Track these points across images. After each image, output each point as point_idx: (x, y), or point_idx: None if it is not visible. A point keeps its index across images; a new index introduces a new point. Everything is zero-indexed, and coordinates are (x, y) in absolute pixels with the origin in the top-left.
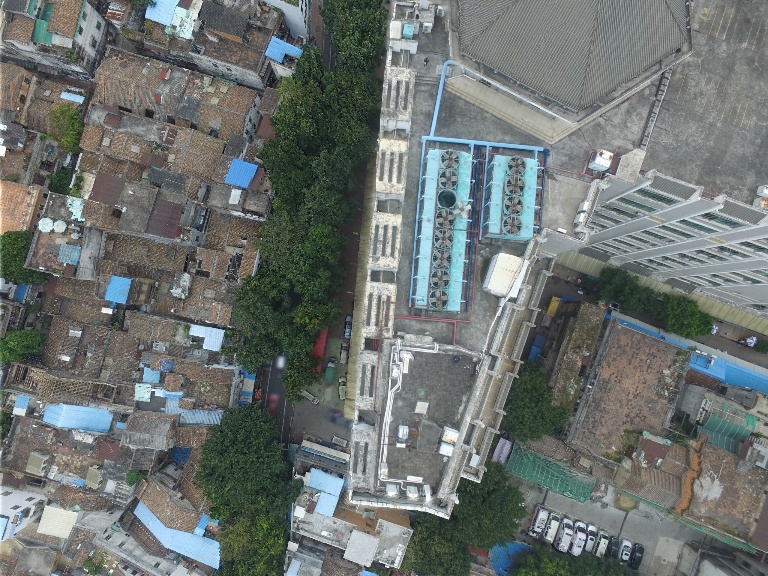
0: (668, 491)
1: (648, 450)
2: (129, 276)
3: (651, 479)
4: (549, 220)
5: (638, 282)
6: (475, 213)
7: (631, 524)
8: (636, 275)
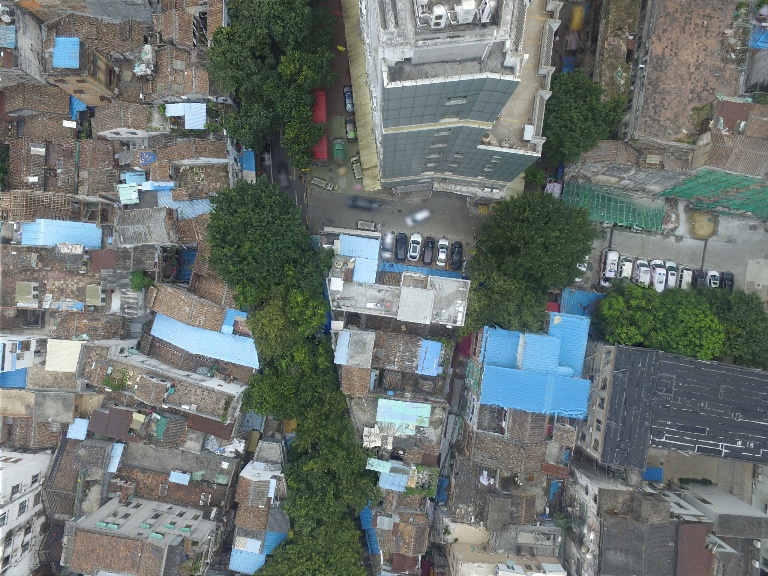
0: (760, 152)
1: (727, 114)
2: None
3: (737, 144)
4: None
5: None
6: None
7: (713, 253)
8: None
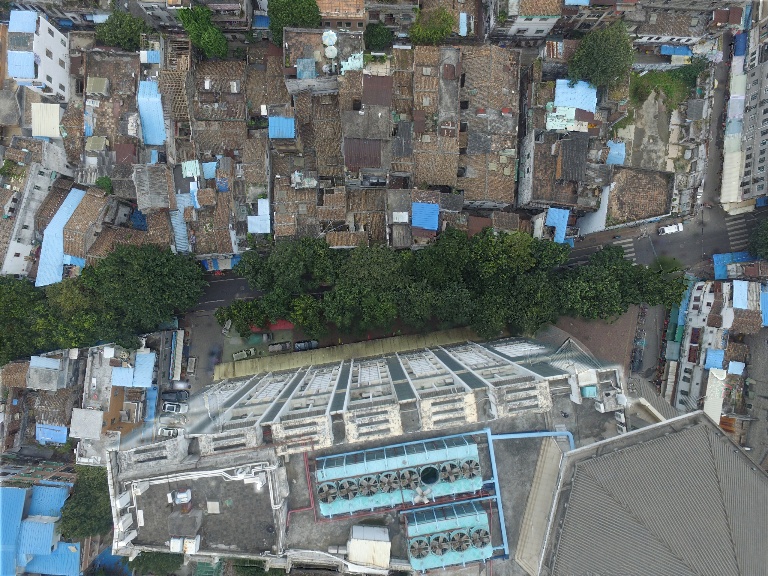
0: None
1: None
2: (300, 128)
3: None
4: (438, 575)
5: None
6: None
7: None
8: None
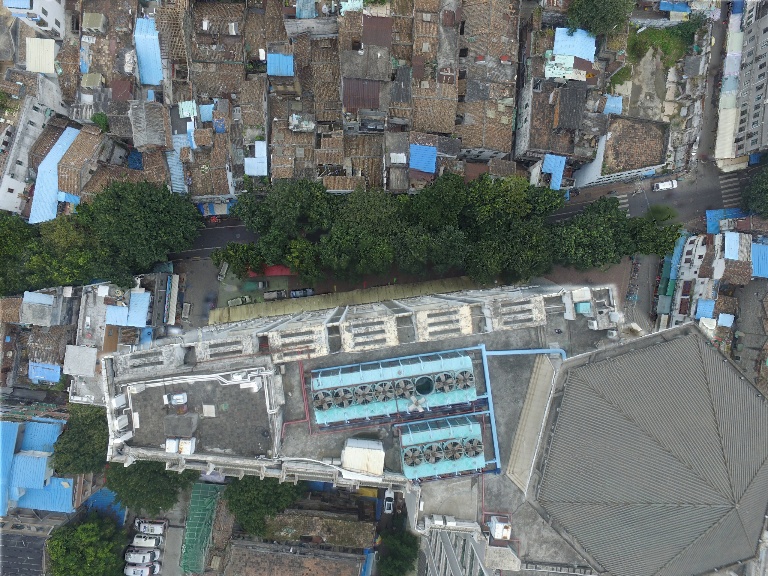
0: None
1: None
2: None
3: None
4: (431, 489)
5: (409, 571)
6: (420, 414)
7: None
8: (416, 567)
